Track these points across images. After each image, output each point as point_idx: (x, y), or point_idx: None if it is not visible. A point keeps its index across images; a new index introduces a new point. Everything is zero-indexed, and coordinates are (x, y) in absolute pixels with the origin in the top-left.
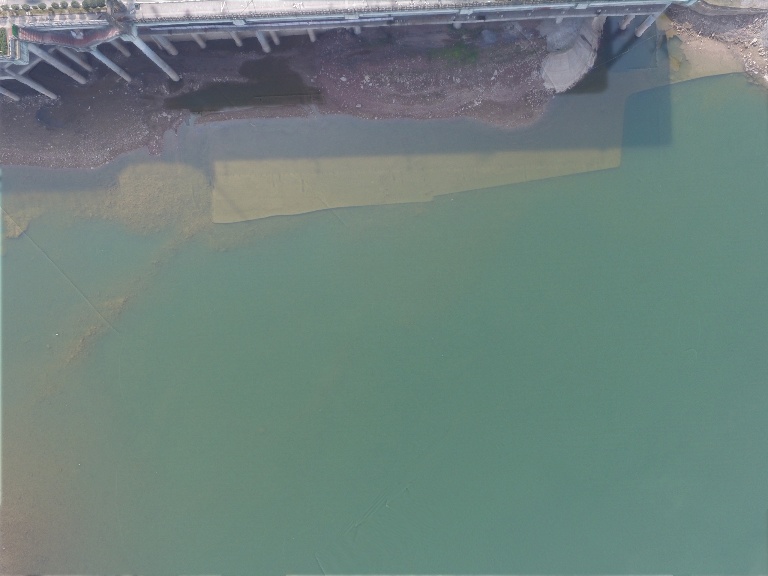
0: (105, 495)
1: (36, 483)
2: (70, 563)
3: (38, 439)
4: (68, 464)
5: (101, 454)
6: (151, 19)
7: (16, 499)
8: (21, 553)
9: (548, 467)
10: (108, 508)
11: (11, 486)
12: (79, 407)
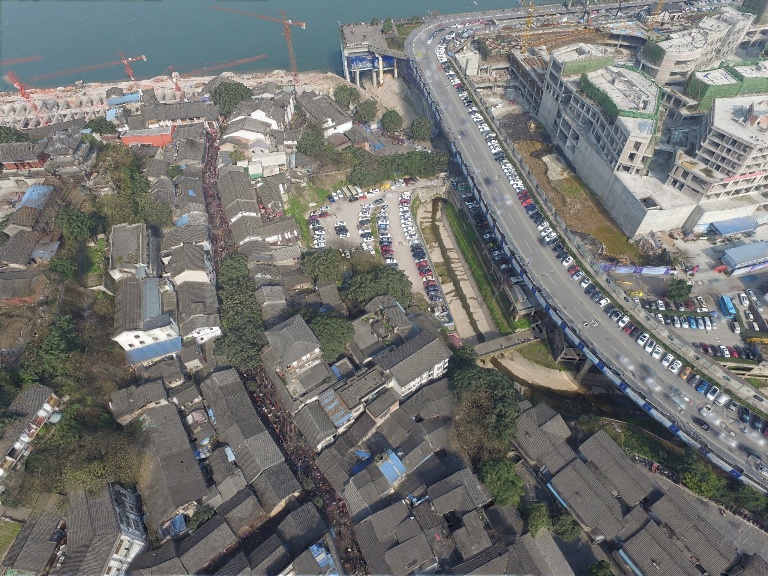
0: None
1: None
2: None
3: None
4: None
5: None
6: (555, 5)
7: None
8: None
9: None
10: None
11: None
12: None
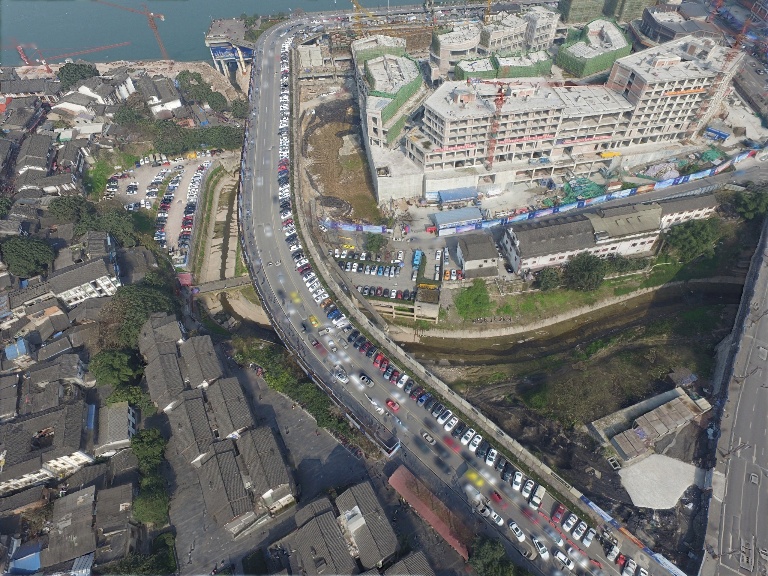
0: None
1: None
2: None
3: None
4: None
5: None
6: (415, 5)
7: None
8: None
9: None
10: None
11: None
12: None
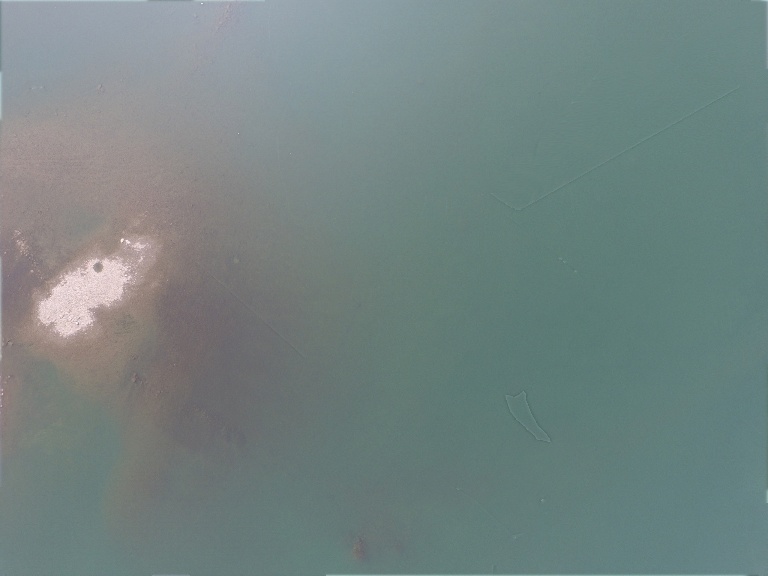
0: (268, 162)
1: (196, 156)
2: (239, 234)
3: (194, 112)
4: (227, 134)
5: (259, 122)
6: None
7: (178, 174)
8: (189, 227)
9: (746, 4)
10: (272, 175)
11: (171, 161)
12: (232, 76)
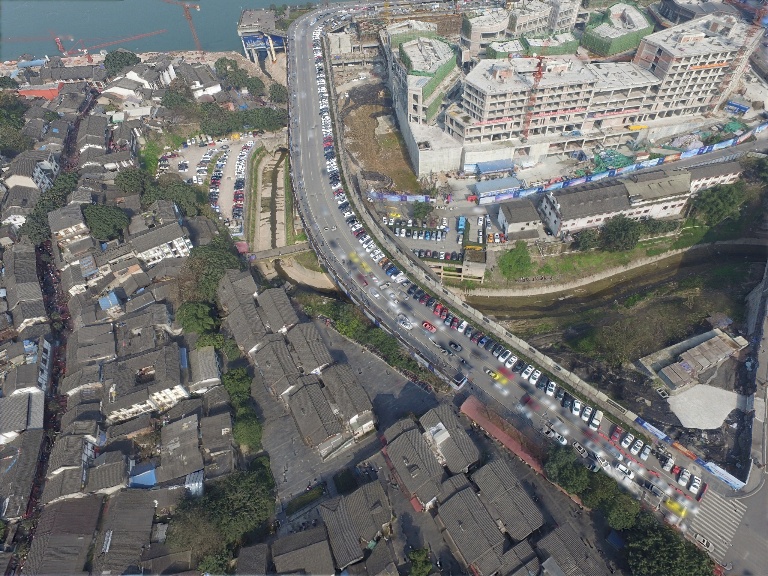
0: None
1: None
2: None
3: None
4: None
5: None
6: None
7: None
8: None
9: None
10: None
11: None
12: None
